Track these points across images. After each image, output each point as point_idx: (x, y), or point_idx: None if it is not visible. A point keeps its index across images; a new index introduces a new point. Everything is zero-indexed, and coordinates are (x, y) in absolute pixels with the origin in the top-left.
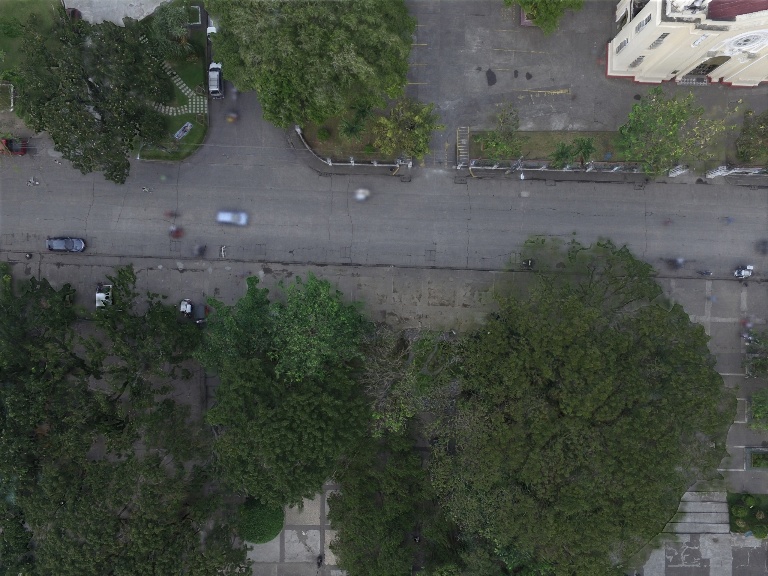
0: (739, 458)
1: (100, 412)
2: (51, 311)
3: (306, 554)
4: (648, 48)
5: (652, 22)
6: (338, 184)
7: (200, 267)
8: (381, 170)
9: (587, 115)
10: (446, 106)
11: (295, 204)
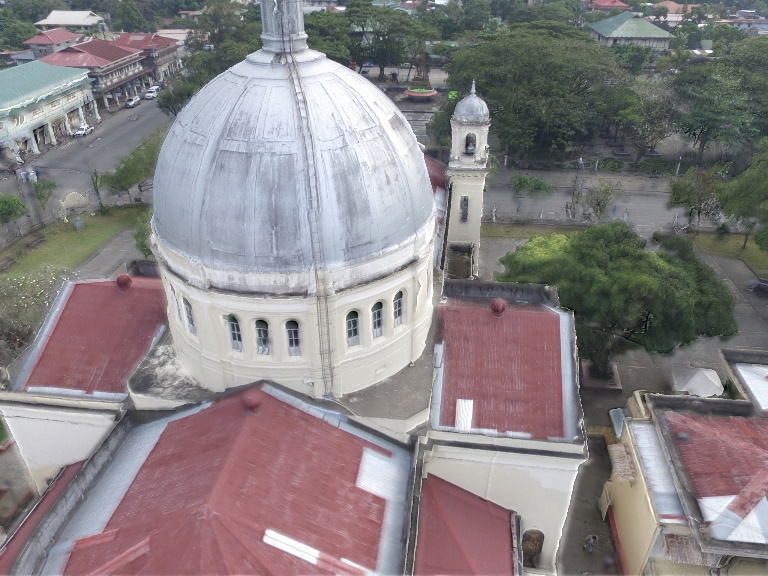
0: None
1: None
2: None
3: None
4: None
5: None
6: None
7: None
8: None
9: None
10: None
11: None
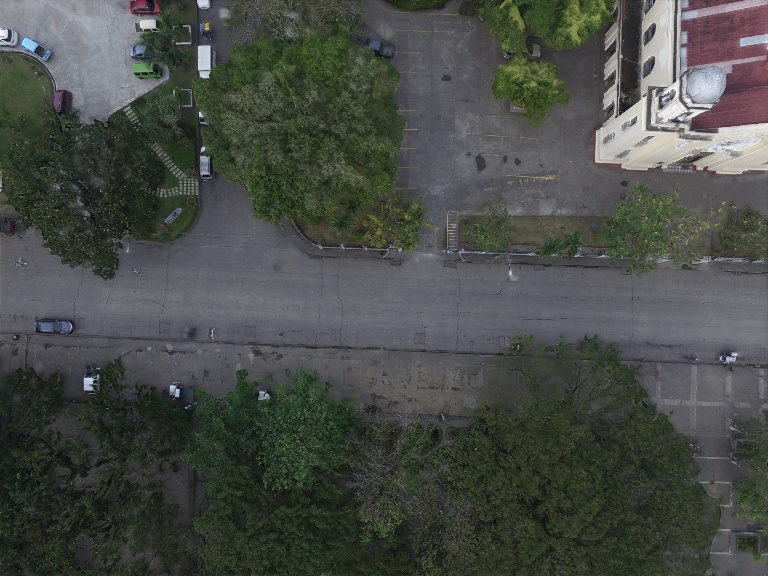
0: (724, 541)
1: (86, 515)
2: (37, 412)
3: None
4: (634, 146)
5: (637, 126)
6: (328, 267)
7: (189, 349)
8: (371, 253)
9: (575, 200)
10: (436, 190)
11: (285, 287)
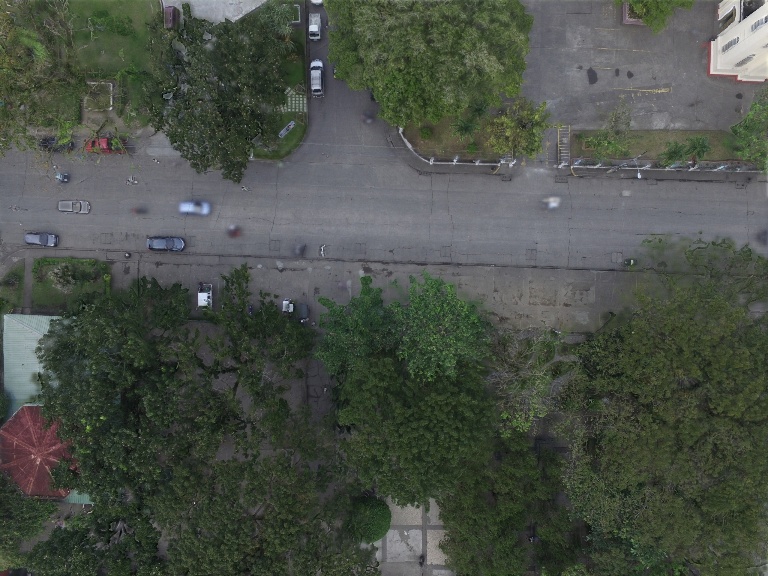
0: None
1: (225, 412)
2: (175, 310)
3: (408, 554)
4: (764, 47)
5: None
6: (438, 183)
7: (300, 266)
8: (482, 169)
9: (689, 114)
10: (547, 105)
11: (395, 203)
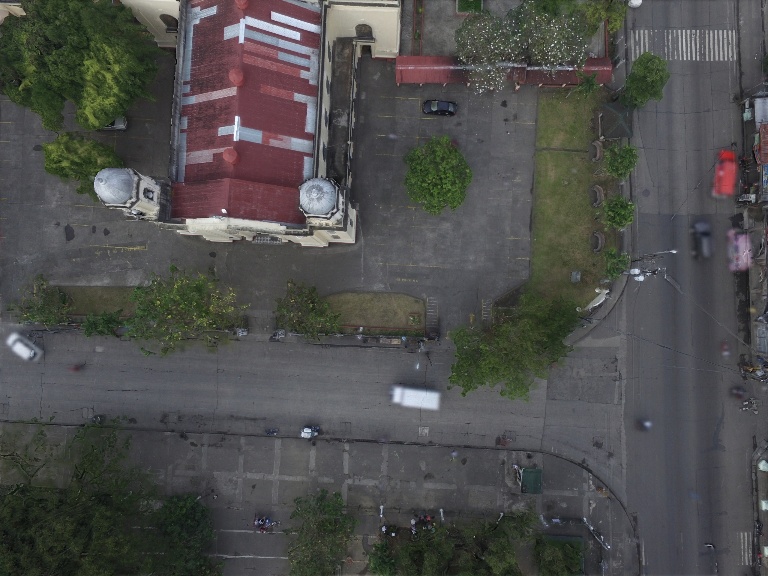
0: None
1: None
2: None
3: None
4: None
5: None
6: None
7: None
8: None
9: (163, 271)
10: (24, 260)
11: None
